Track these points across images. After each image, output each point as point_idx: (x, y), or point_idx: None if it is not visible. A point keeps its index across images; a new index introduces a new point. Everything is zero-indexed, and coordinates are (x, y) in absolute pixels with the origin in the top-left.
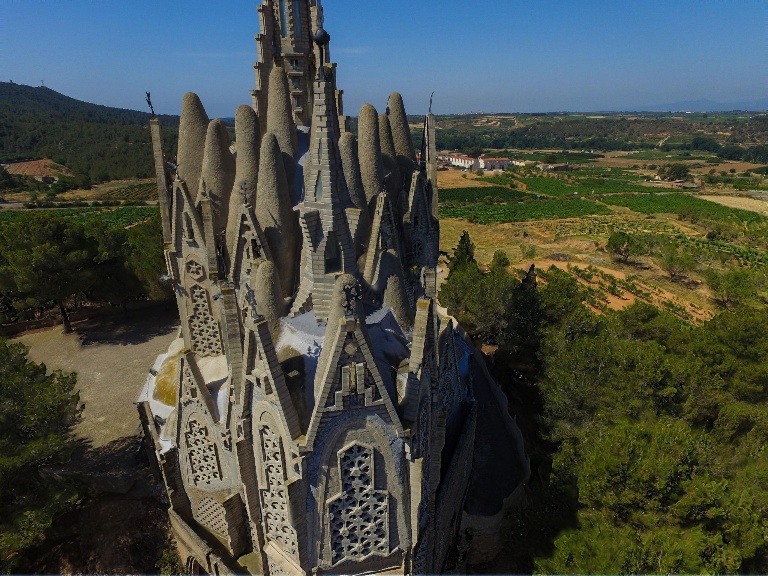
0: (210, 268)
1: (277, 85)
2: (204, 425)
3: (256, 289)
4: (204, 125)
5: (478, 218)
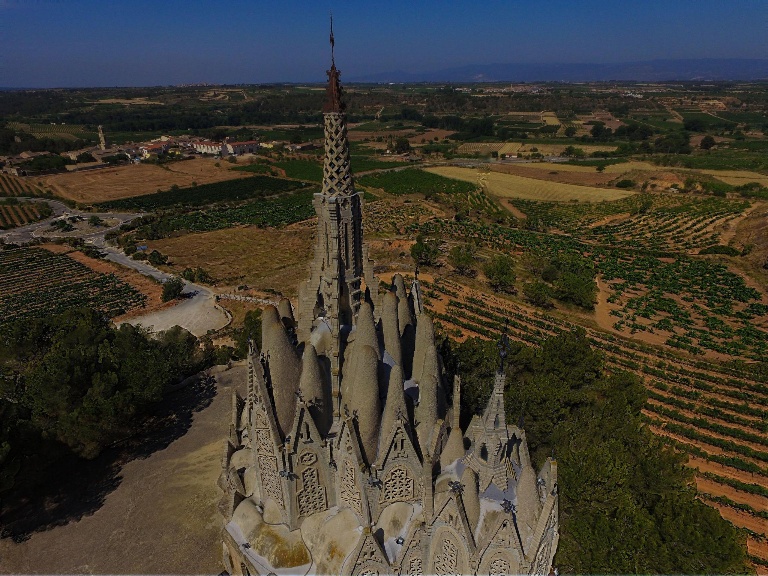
0: (359, 464)
1: (369, 317)
2: (377, 570)
3: (467, 487)
4: (291, 345)
5: (266, 223)
